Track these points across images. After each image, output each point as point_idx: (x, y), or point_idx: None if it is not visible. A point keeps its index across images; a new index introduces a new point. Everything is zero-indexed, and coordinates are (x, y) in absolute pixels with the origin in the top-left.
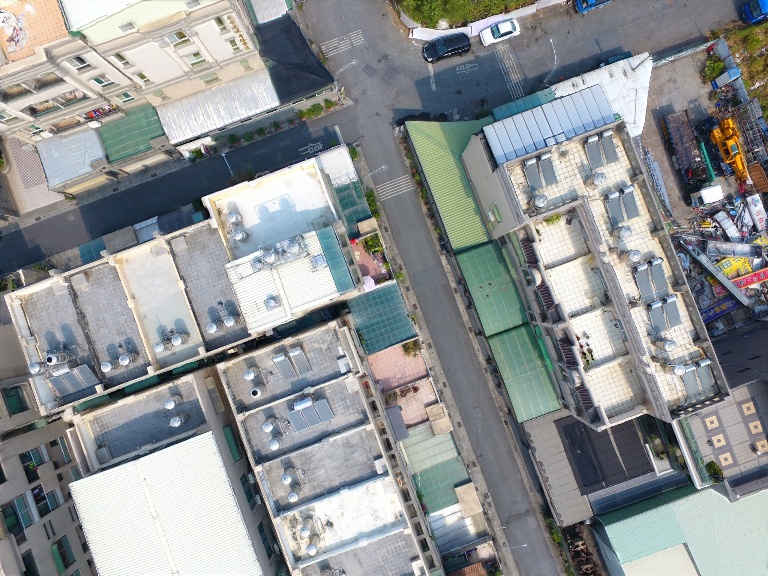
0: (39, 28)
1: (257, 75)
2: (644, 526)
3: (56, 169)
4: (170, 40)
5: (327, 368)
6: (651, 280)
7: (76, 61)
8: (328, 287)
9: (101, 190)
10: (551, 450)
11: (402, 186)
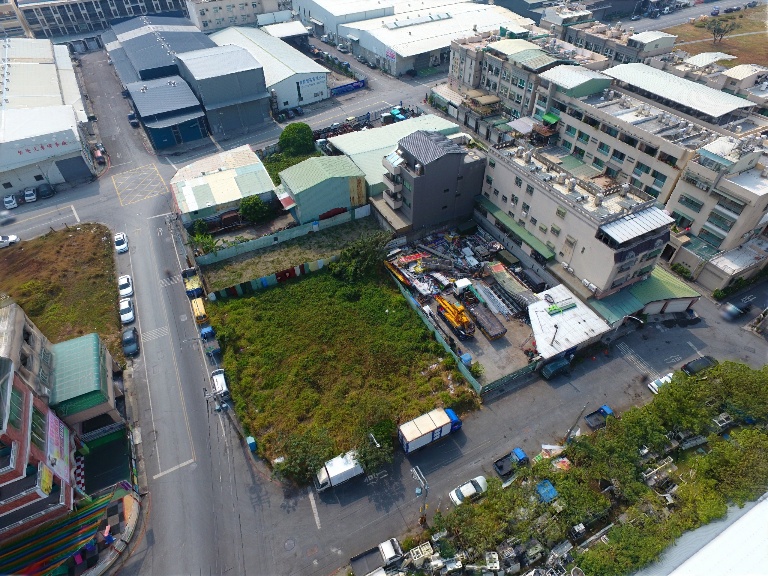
0: None
1: None
2: None
3: None
4: None
5: None
6: None
7: None
8: None
9: None
10: None
11: None
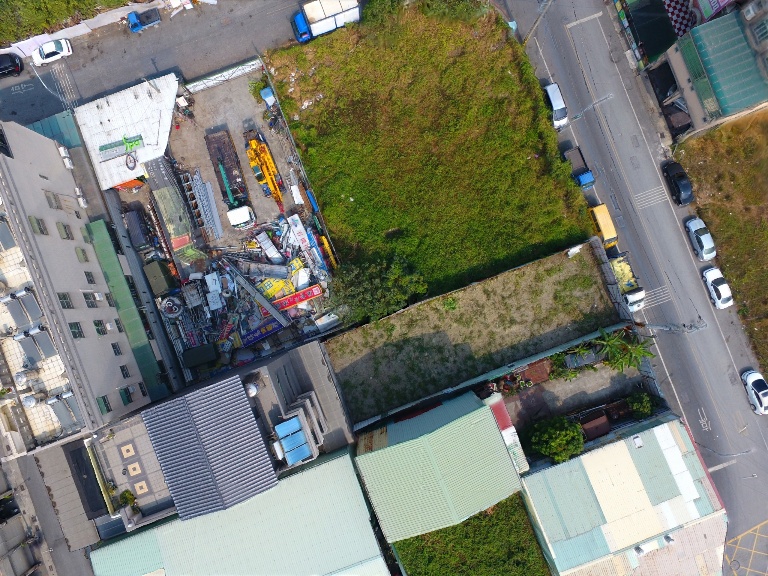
0: None
1: None
2: (127, 551)
3: None
4: None
5: None
6: None
7: None
8: None
9: None
10: (59, 475)
11: None
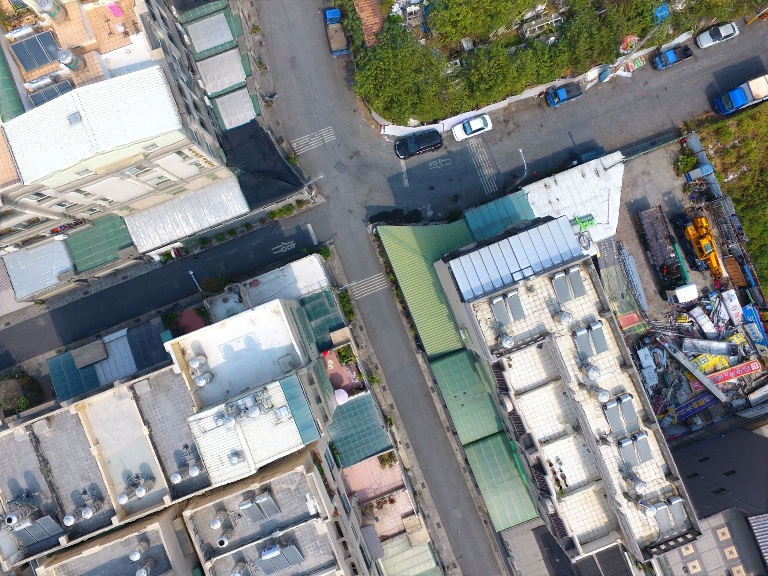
0: None
1: (226, 182)
2: None
3: (23, 281)
4: (131, 172)
5: (296, 509)
6: (621, 415)
7: (35, 196)
8: (293, 439)
9: (71, 294)
10: (529, 559)
11: (377, 284)
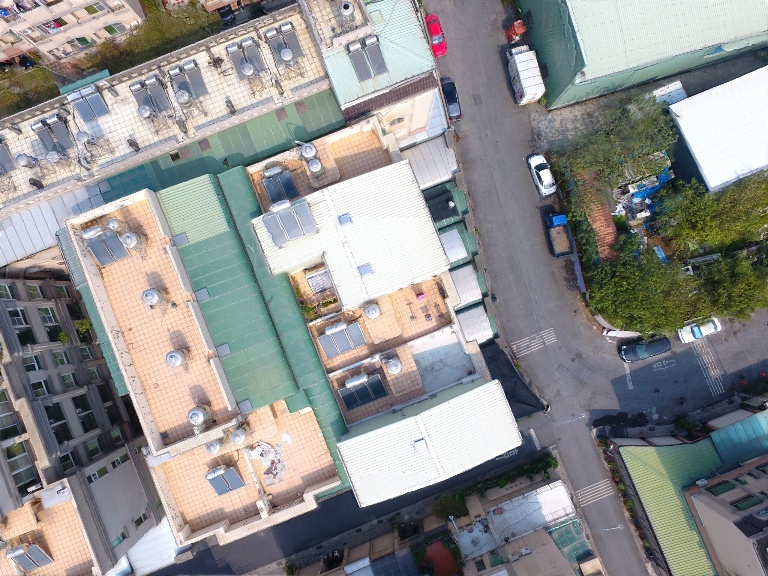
0: (298, 458)
1: None
2: None
3: None
4: None
5: None
6: None
7: None
8: None
9: None
10: None
11: (602, 491)
